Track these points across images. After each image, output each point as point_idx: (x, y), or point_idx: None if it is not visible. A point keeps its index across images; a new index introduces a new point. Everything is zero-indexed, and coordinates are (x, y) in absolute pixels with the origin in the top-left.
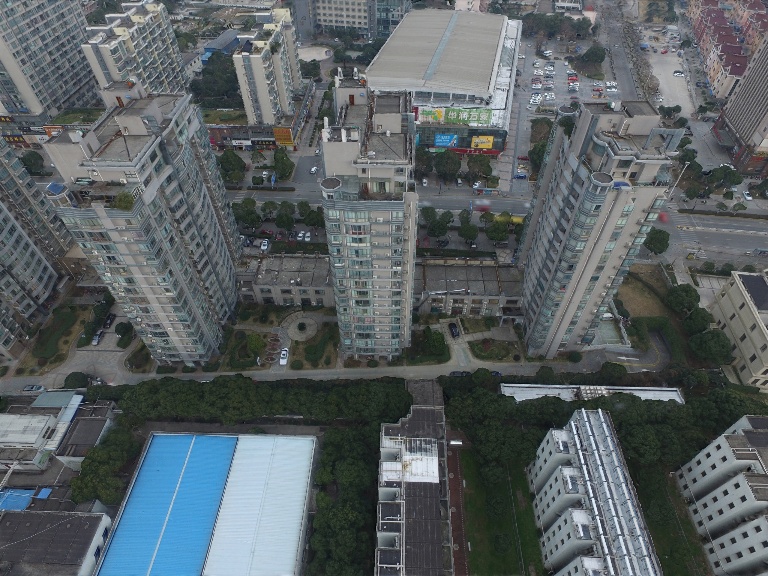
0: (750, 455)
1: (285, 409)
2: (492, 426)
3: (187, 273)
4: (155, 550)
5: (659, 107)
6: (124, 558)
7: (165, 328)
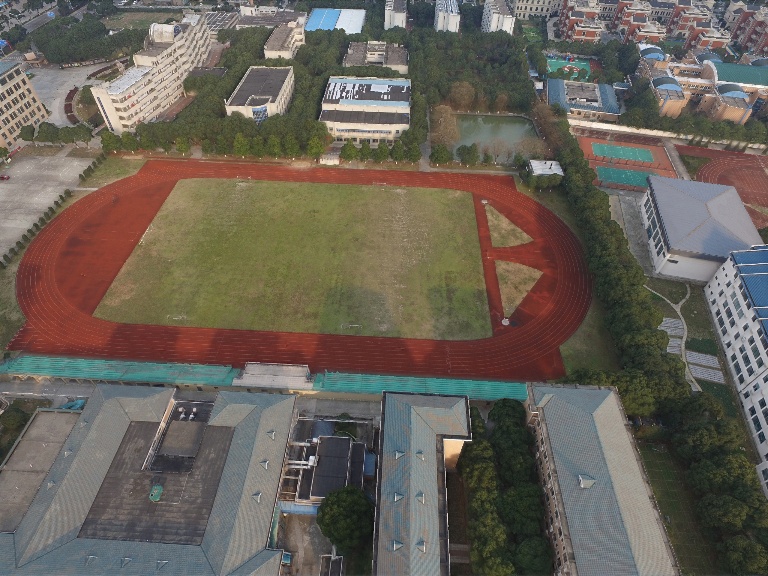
0: None
1: (356, 5)
2: (422, 4)
3: None
4: (322, 19)
5: None
6: (314, 20)
7: None
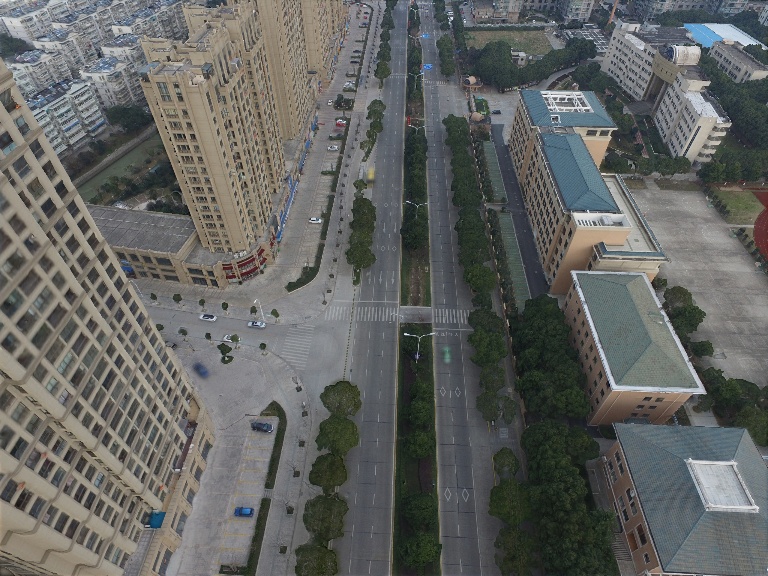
0: None
1: (716, 19)
2: None
3: None
4: None
5: None
6: None
7: None
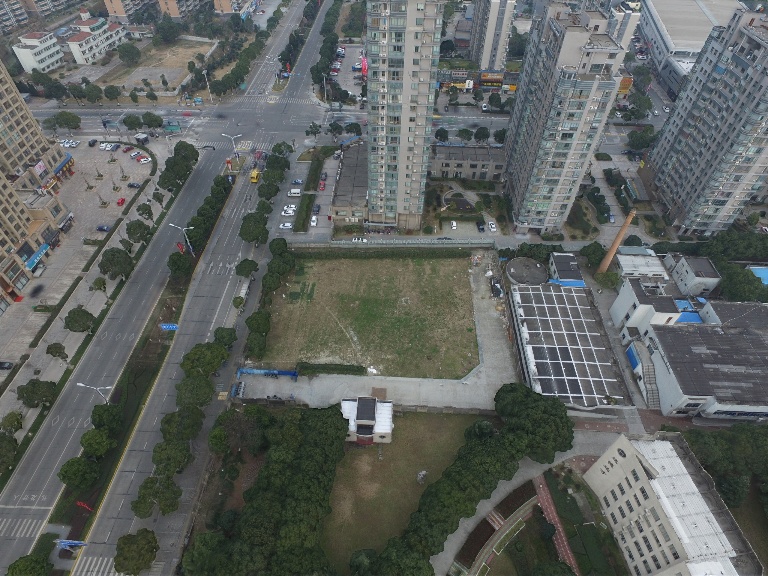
0: None
1: None
2: None
3: None
4: None
5: None
6: None
7: (731, 197)
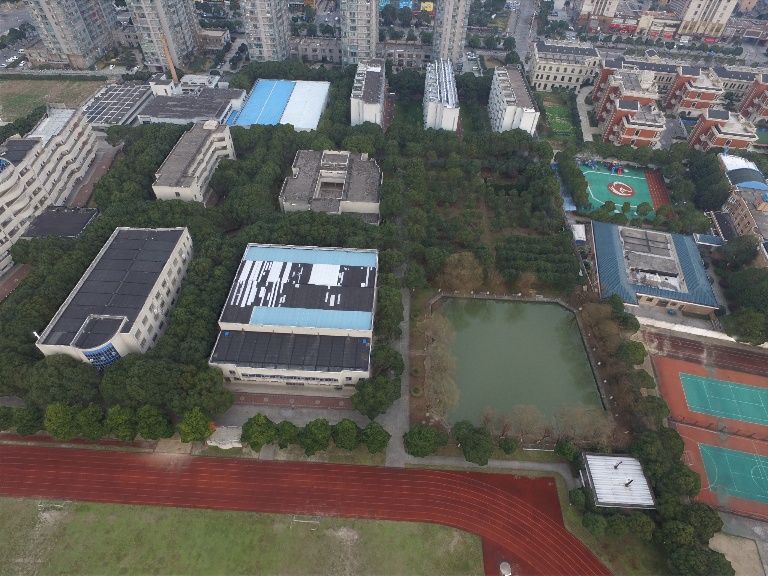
0: (503, 70)
1: (317, 74)
2: None
3: (275, 10)
4: (267, 100)
5: (541, 1)
6: (254, 102)
7: (262, 41)
